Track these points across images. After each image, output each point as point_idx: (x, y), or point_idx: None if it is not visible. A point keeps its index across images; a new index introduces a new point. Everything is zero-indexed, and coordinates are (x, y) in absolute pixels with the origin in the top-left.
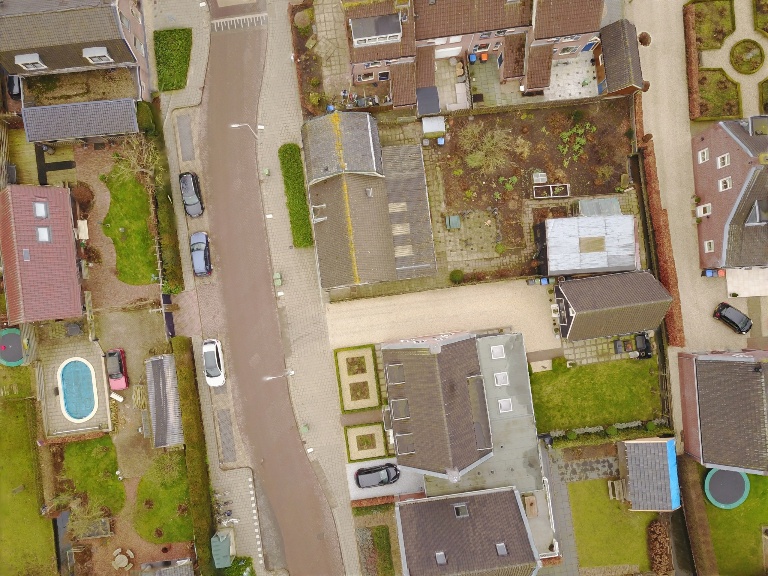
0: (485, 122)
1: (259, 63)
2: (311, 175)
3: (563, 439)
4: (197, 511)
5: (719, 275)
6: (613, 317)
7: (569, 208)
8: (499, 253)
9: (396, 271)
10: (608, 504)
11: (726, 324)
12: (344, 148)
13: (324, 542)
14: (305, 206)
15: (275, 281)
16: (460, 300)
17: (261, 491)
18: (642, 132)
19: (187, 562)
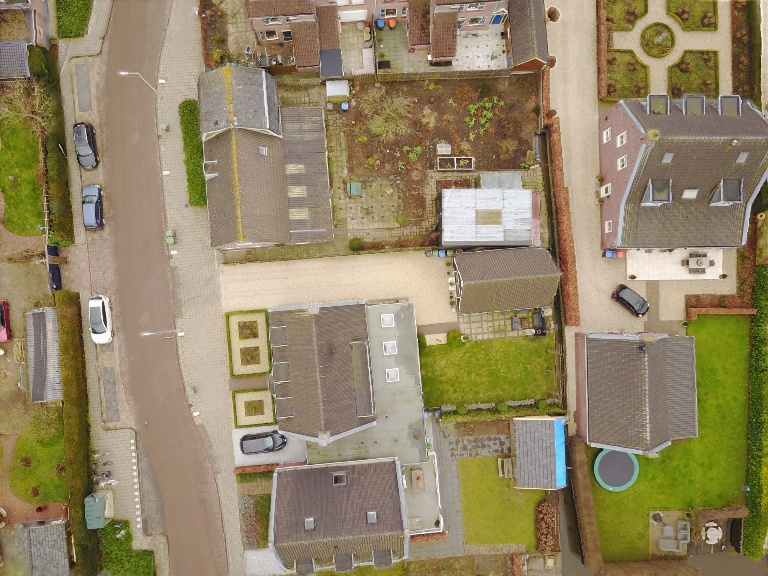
0: (392, 90)
1: (164, 16)
2: (202, 129)
3: (453, 414)
4: (72, 470)
5: (618, 256)
6: (502, 289)
7: (473, 182)
8: (400, 223)
9: (290, 234)
10: (497, 482)
11: (623, 306)
12: (235, 102)
13: (205, 508)
14: (202, 164)
15: (167, 238)
16: (358, 269)
17: (143, 454)
18: (548, 109)
19: (59, 522)
